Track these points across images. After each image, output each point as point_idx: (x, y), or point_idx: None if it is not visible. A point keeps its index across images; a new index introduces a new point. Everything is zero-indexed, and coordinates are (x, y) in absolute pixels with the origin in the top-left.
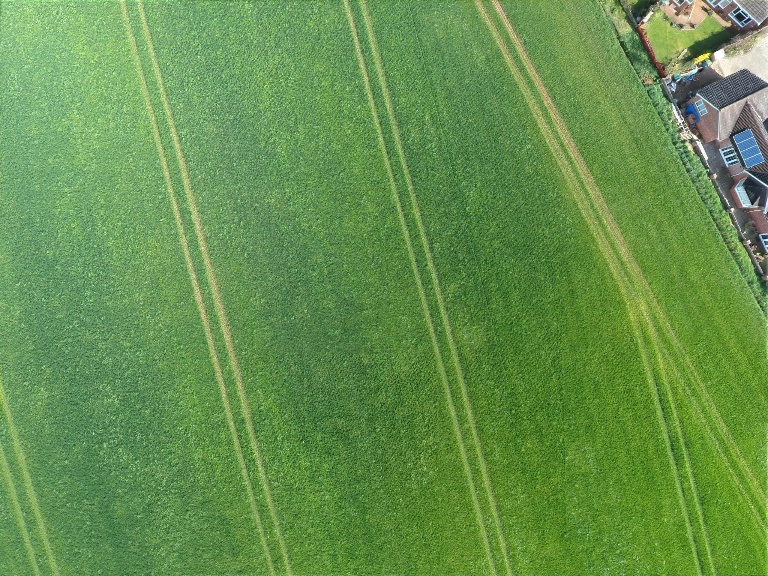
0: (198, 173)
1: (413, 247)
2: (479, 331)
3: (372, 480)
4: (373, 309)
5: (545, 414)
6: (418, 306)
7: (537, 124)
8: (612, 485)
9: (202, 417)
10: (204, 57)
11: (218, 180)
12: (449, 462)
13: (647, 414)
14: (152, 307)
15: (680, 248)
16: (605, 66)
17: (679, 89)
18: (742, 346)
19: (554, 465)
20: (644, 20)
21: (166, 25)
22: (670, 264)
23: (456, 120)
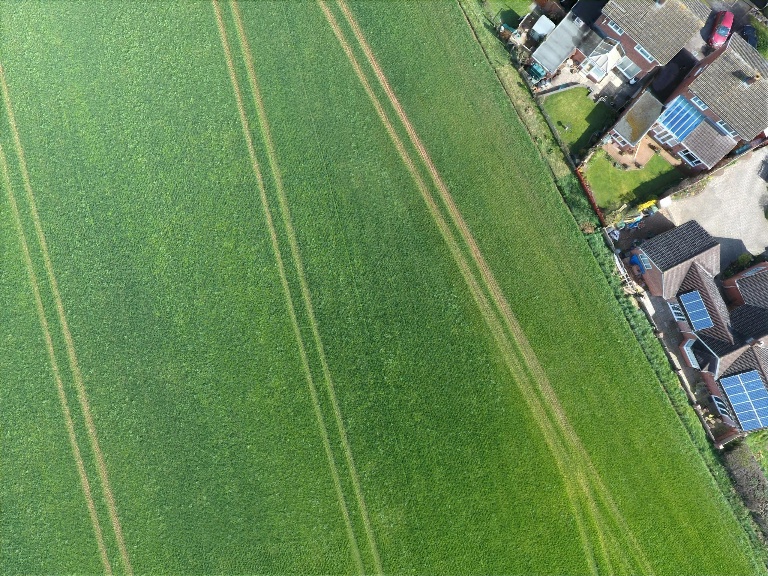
0: (85, 348)
1: (325, 423)
2: (398, 513)
3: None
4: (280, 493)
5: None
6: (330, 488)
7: (464, 281)
8: None
9: None
10: (92, 218)
11: (107, 355)
12: None
13: None
14: (33, 499)
15: (623, 413)
16: (540, 213)
17: (623, 236)
18: (692, 519)
19: None
20: None
21: (50, 184)
22: (612, 431)
23: (373, 280)
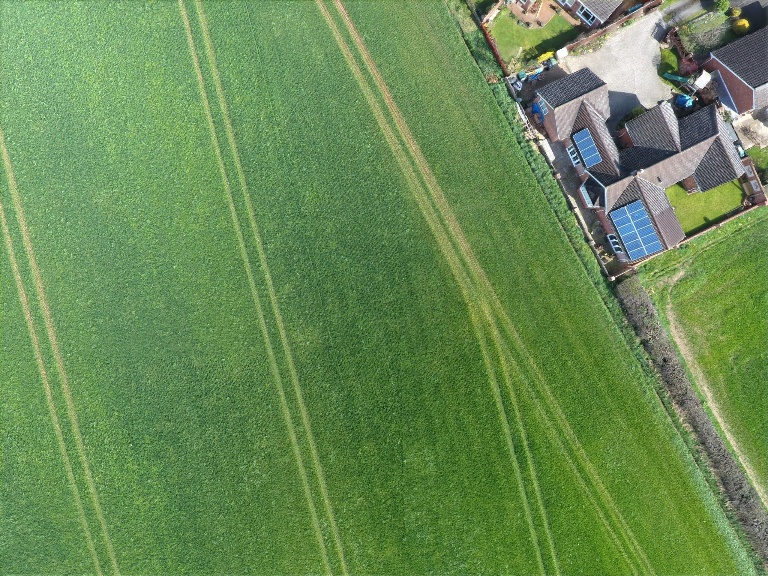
0: (23, 173)
1: (246, 248)
2: (314, 332)
3: (203, 483)
4: (204, 310)
5: (383, 416)
6: (251, 307)
7: (377, 123)
8: (452, 488)
9: (26, 420)
10: (31, 55)
11: (44, 180)
12: (283, 465)
13: (489, 416)
14: None
15: (525, 249)
16: (449, 65)
17: (526, 88)
18: (588, 348)
19: (392, 468)
20: (490, 18)
21: None
22: (514, 265)
23: (292, 119)
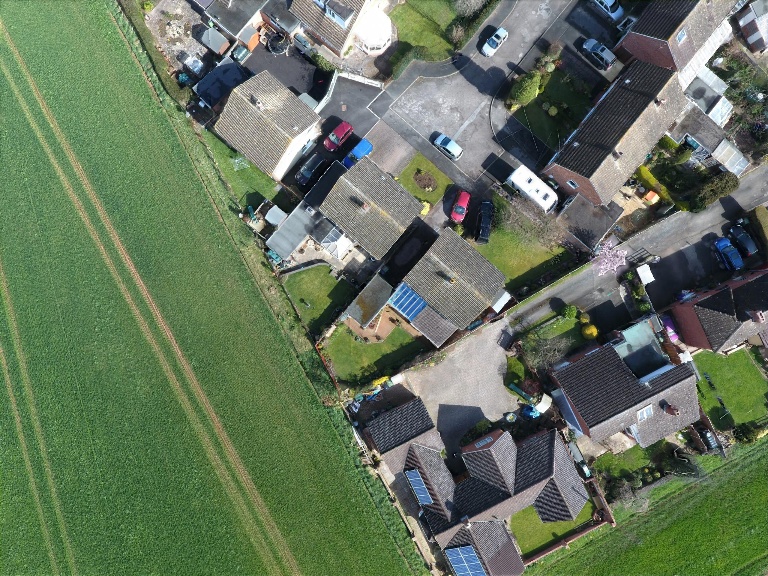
0: None
1: None
2: None
3: None
4: None
5: None
6: None
7: (206, 455)
8: None
9: None
10: None
11: None
12: None
13: None
14: None
15: None
16: (282, 388)
17: (364, 407)
18: None
19: None
20: (327, 335)
21: None
22: None
23: (115, 458)
